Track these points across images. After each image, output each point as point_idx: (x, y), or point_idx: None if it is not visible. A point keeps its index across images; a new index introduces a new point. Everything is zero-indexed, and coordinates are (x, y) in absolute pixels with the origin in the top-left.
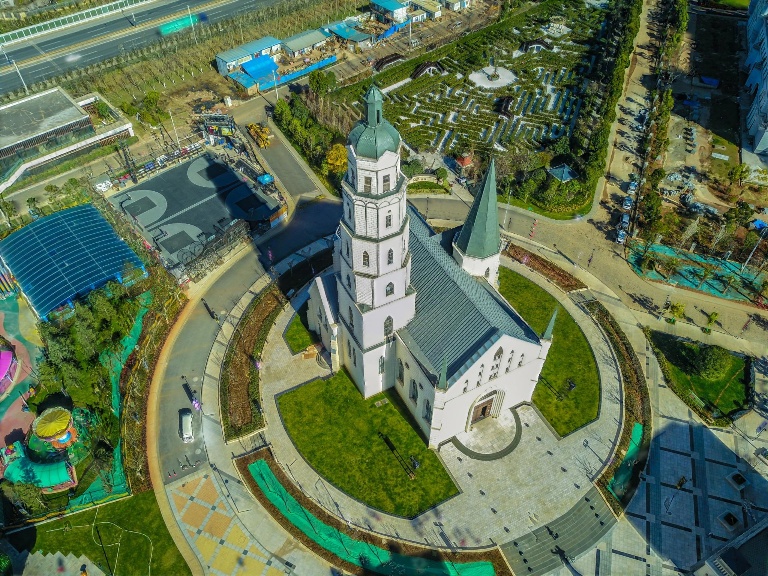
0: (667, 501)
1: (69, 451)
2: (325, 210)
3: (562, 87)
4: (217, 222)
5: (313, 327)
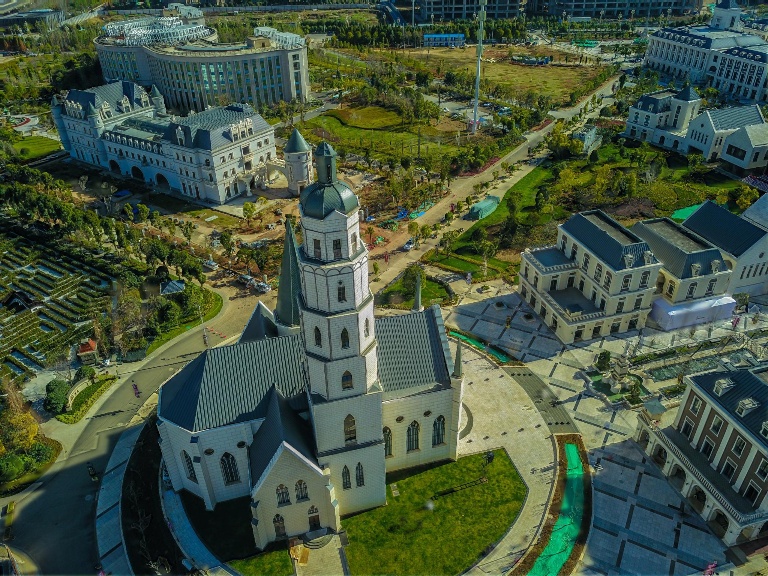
0: (513, 340)
1: None
2: (40, 508)
3: (36, 261)
4: None
5: (265, 541)
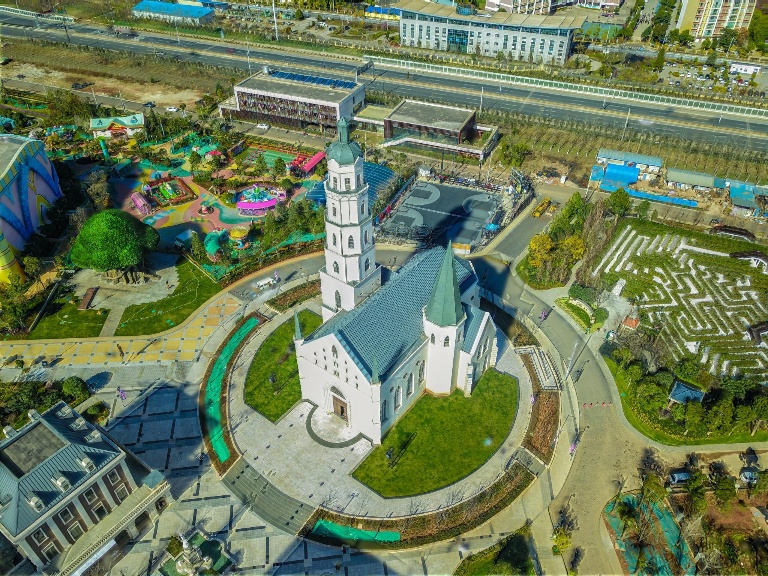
0: (330, 574)
1: (233, 251)
2: (495, 270)
3: None
4: (435, 228)
5: None
